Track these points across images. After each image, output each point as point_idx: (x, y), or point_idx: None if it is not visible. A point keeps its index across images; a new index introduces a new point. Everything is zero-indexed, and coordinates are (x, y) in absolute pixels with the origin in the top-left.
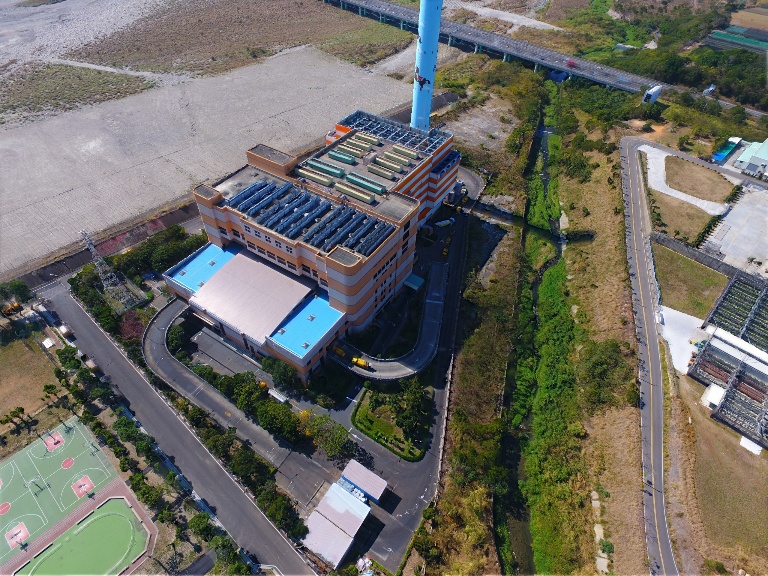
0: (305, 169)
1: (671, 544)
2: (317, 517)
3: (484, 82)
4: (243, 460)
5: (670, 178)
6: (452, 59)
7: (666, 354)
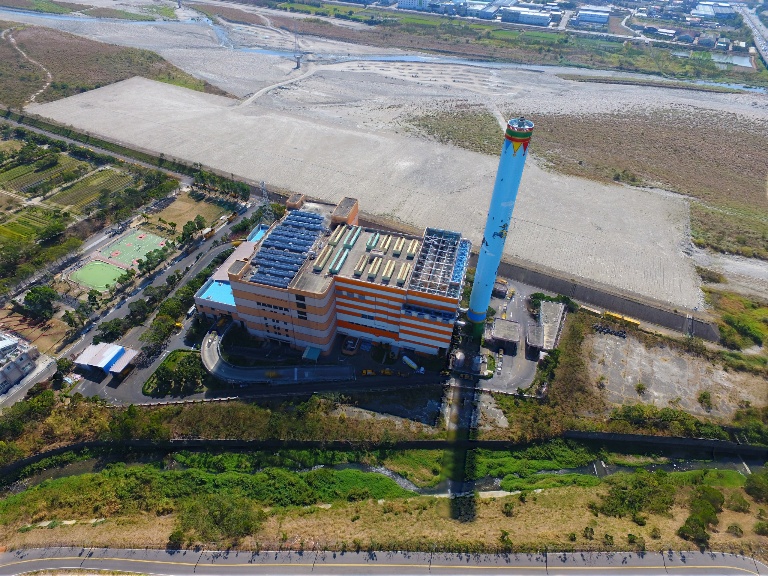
0: (341, 227)
1: (36, 571)
2: (103, 346)
3: None
4: (138, 303)
5: None
6: None
7: None
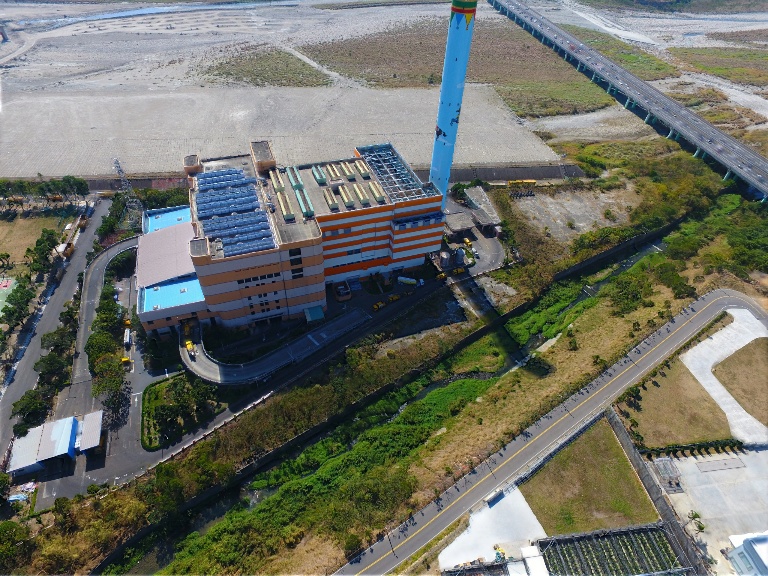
0: (275, 172)
1: None
2: (39, 431)
3: (637, 170)
4: (48, 360)
5: (729, 363)
6: (632, 137)
7: (448, 535)
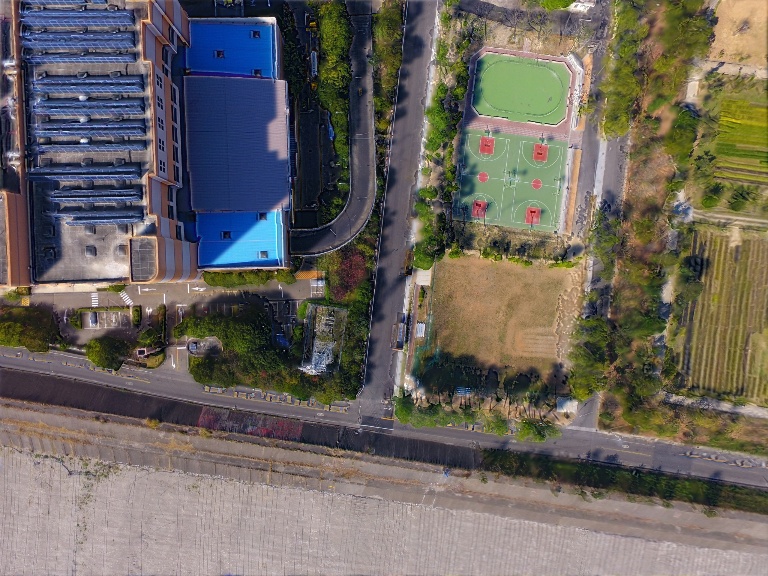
0: None
1: None
2: None
3: None
4: (390, 24)
5: None
6: None
7: None
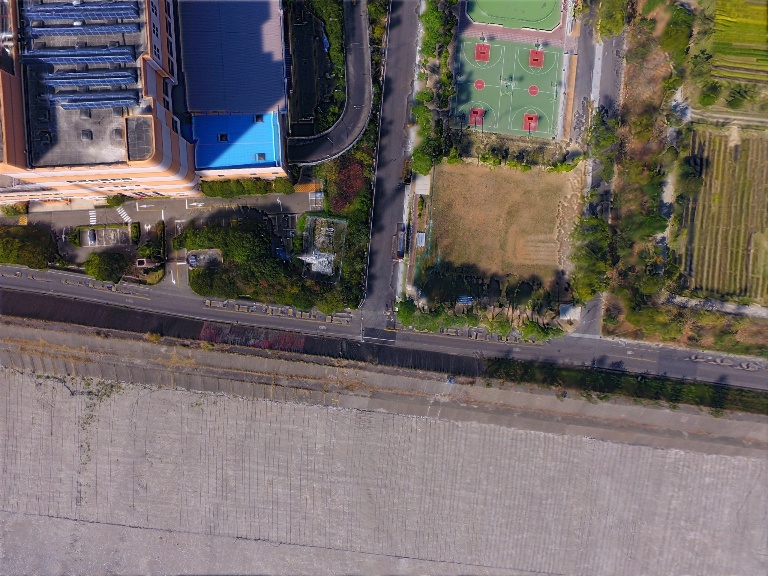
0: None
1: None
2: None
3: None
4: None
5: None
6: None
7: None
